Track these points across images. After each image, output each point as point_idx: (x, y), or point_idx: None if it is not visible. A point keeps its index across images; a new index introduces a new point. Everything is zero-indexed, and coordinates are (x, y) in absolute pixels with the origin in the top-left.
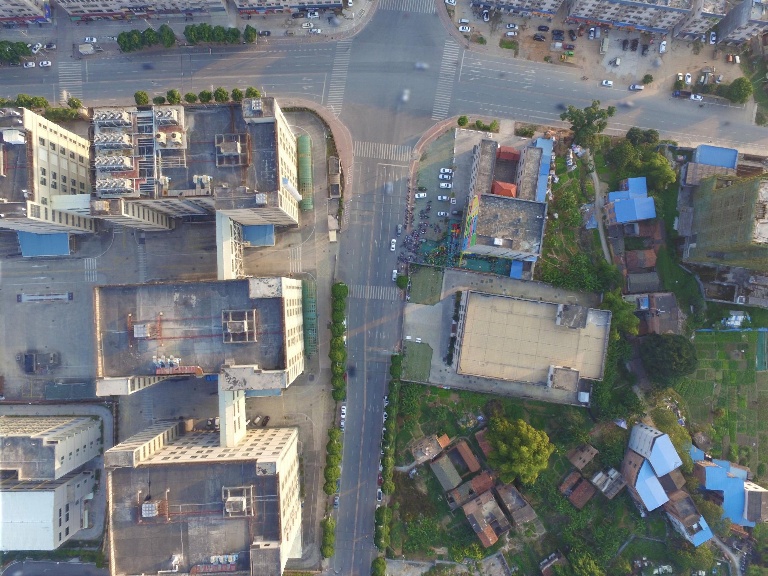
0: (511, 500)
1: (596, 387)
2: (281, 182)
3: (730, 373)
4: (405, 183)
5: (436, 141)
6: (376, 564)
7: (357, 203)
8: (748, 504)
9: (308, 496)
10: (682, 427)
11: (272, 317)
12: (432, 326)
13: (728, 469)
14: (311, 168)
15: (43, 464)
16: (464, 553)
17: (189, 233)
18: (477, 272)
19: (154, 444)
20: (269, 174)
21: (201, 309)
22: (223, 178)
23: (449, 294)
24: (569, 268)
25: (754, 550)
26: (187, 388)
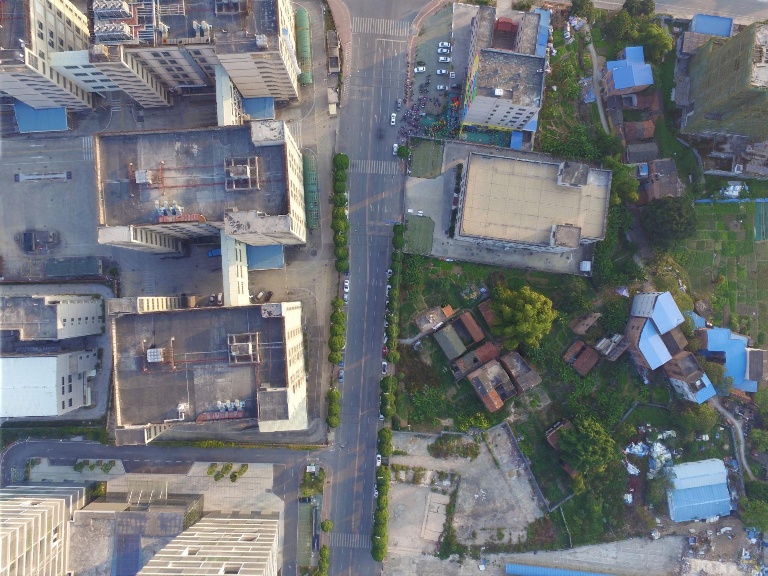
0: (516, 366)
1: (598, 254)
2: (281, 31)
3: (729, 244)
4: (404, 58)
5: (434, 16)
6: (382, 432)
7: (356, 78)
8: (750, 363)
9: (313, 371)
10: (683, 292)
11: (274, 165)
12: (433, 199)
13: (729, 335)
14: (310, 42)
15: (45, 325)
16: (470, 422)
17: (188, 110)
18: (477, 144)
19: (157, 303)
20: (269, 23)
21: (203, 158)
22: (223, 27)
23: (450, 167)
24: (569, 137)
25: (756, 415)
26: (189, 265)
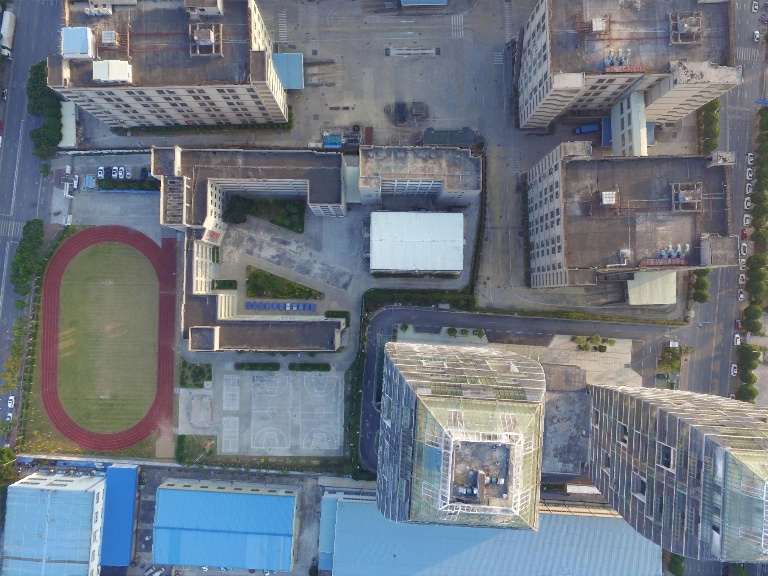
0: None
1: None
2: None
3: None
4: None
5: None
6: (755, 307)
7: None
8: None
9: None
10: None
11: (715, 22)
12: None
13: None
14: None
15: (466, 177)
16: None
17: None
18: None
19: None
20: None
21: (646, 12)
22: None
23: None
24: None
25: None
26: (552, 142)
